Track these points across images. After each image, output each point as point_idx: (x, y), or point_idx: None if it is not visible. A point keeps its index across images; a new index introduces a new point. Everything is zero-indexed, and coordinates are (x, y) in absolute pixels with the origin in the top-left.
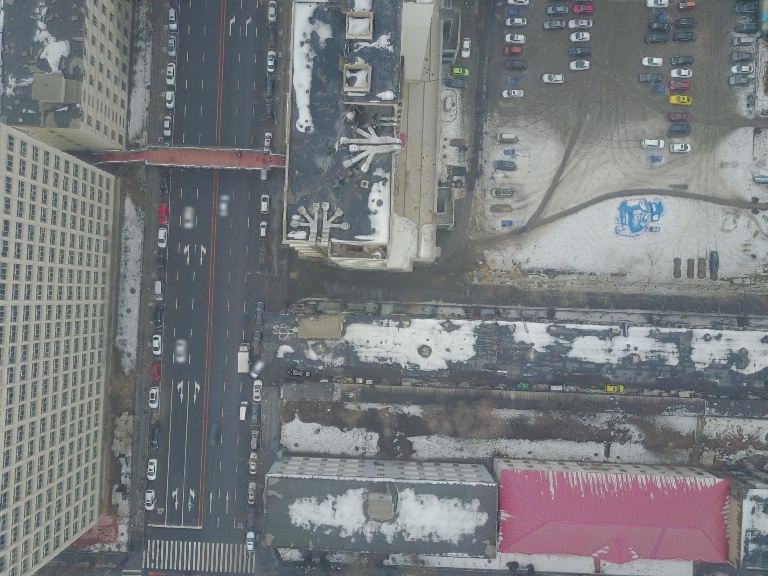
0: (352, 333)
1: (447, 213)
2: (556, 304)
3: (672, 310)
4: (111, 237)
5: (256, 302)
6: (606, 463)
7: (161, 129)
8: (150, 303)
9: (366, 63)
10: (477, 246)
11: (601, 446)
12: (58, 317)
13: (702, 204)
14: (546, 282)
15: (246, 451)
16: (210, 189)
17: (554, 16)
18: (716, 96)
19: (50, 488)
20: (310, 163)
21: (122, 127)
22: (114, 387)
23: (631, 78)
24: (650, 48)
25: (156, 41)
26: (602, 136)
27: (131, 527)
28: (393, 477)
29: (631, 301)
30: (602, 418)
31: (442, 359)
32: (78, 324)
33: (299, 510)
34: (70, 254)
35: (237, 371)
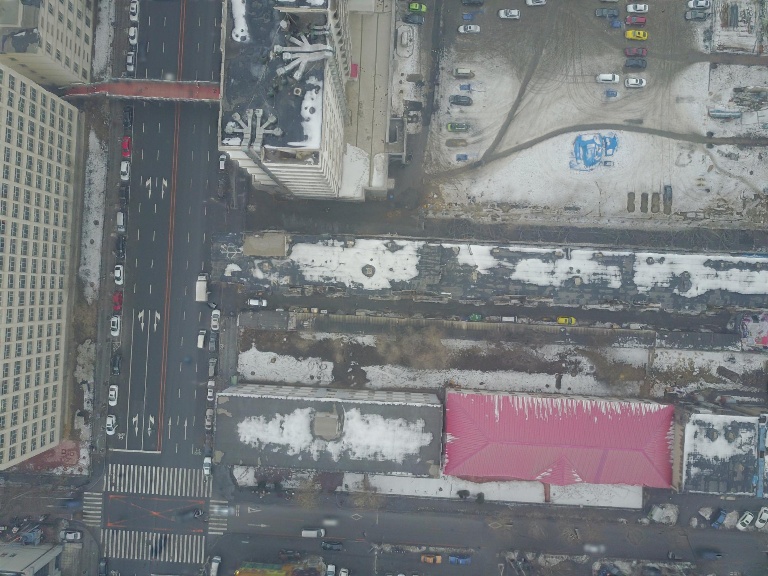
0: (298, 252)
1: (399, 143)
2: (510, 237)
3: (625, 244)
4: (74, 168)
5: None
6: (557, 394)
7: (124, 64)
8: (112, 233)
9: None
10: (432, 180)
11: (552, 378)
12: (13, 234)
13: (657, 139)
14: (500, 215)
15: (204, 379)
16: (171, 123)
17: None
18: (672, 31)
19: (5, 399)
20: (245, 71)
21: (86, 62)
22: (77, 315)
23: (587, 14)
24: None
25: None
26: (557, 71)
27: (93, 451)
28: (340, 398)
29: (584, 235)
30: (554, 350)
31: (385, 278)
32: (36, 246)
33: (248, 428)
34: (27, 175)
35: (195, 299)
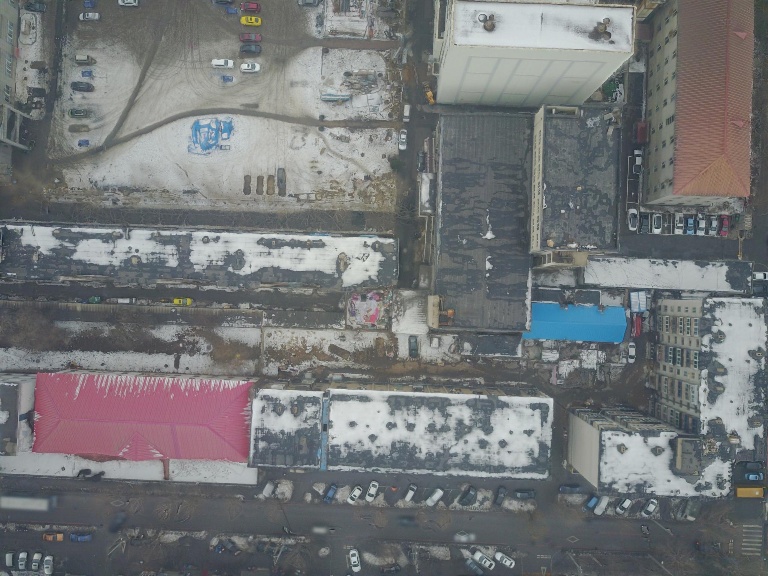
0: None
1: None
2: (130, 221)
3: (242, 226)
4: None
5: None
6: (172, 373)
7: None
8: None
9: None
10: (56, 165)
11: (171, 358)
12: None
13: (272, 122)
14: (120, 199)
15: None
16: None
17: None
18: (287, 17)
19: None
20: None
21: None
22: None
23: (205, 0)
24: None
25: None
26: (176, 57)
27: None
28: None
29: (203, 217)
30: (172, 331)
31: None
32: None
33: None
34: None
35: None
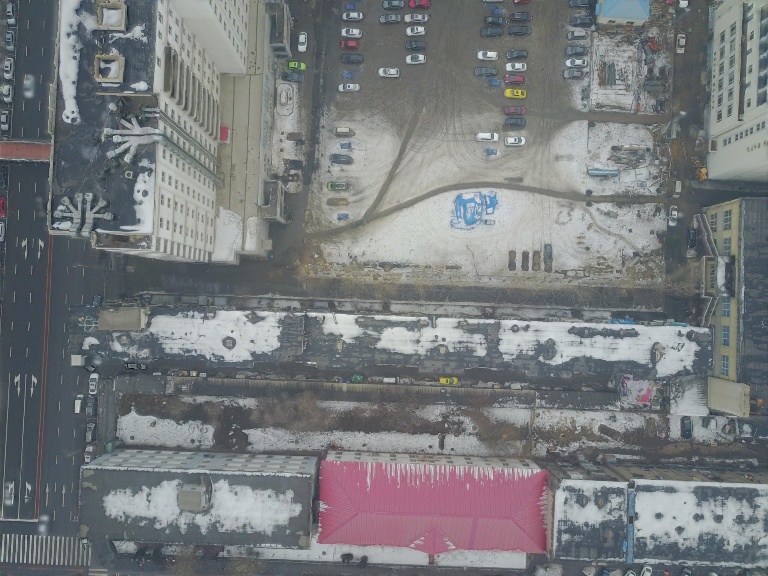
0: (157, 325)
1: (272, 206)
2: (392, 297)
3: (507, 302)
4: None
5: (93, 296)
6: (439, 455)
7: None
8: None
9: (120, 54)
10: (313, 239)
11: (435, 438)
12: None
13: (537, 197)
14: (381, 275)
15: (82, 444)
16: None
17: (391, 10)
18: (551, 90)
19: None
20: (76, 154)
21: None
22: None
23: (467, 72)
24: (486, 42)
25: None
26: (438, 130)
27: None
28: (208, 469)
29: (466, 294)
30: (436, 410)
31: (246, 350)
32: None
33: (114, 502)
34: None
35: (70, 364)
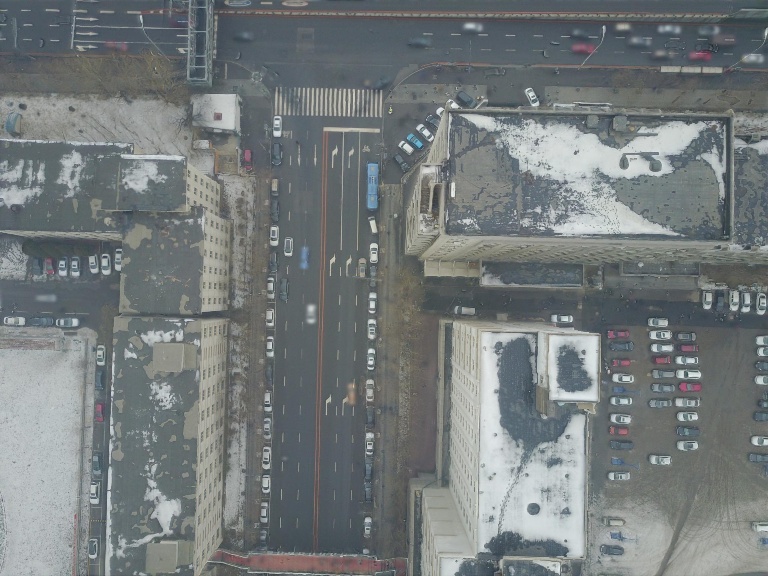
0: None
1: None
2: None
3: None
4: None
5: None
6: None
7: (257, 514)
8: None
9: None
10: None
11: None
12: None
13: None
14: None
15: None
16: None
17: (660, 393)
18: None
19: None
20: None
21: (218, 519)
22: None
23: (740, 457)
24: (759, 425)
25: (250, 422)
26: (711, 517)
27: None
28: None
29: None
30: None
31: None
32: None
33: None
34: None
35: None
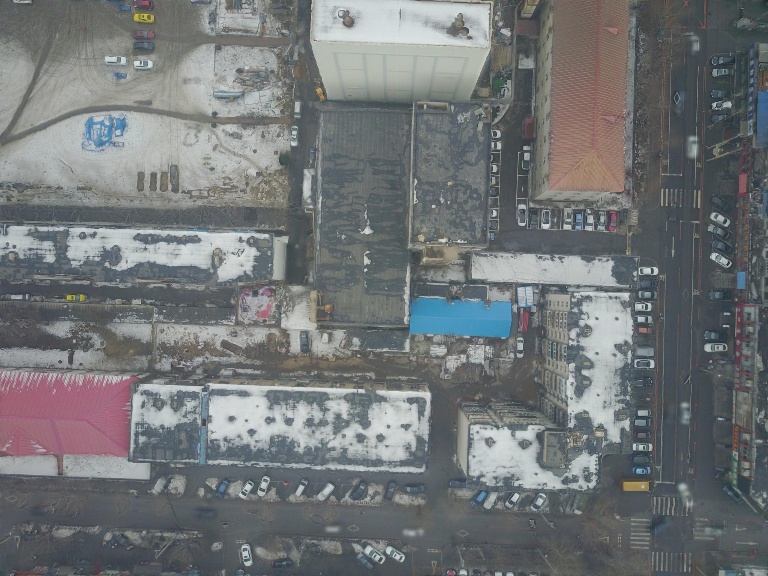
0: None
1: None
2: (25, 217)
3: (136, 222)
4: None
5: None
6: (66, 369)
7: None
8: None
9: None
10: None
11: (65, 354)
12: None
13: (165, 119)
14: (14, 196)
15: None
16: None
17: None
18: (180, 14)
19: None
20: None
21: None
22: None
23: None
24: None
25: None
26: (70, 54)
27: None
28: None
29: (97, 214)
30: (66, 327)
31: None
32: None
33: None
34: None
35: None
